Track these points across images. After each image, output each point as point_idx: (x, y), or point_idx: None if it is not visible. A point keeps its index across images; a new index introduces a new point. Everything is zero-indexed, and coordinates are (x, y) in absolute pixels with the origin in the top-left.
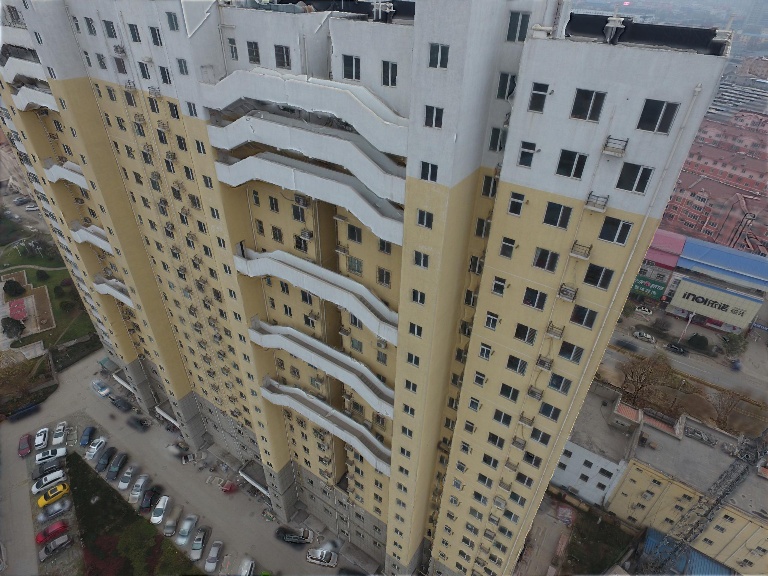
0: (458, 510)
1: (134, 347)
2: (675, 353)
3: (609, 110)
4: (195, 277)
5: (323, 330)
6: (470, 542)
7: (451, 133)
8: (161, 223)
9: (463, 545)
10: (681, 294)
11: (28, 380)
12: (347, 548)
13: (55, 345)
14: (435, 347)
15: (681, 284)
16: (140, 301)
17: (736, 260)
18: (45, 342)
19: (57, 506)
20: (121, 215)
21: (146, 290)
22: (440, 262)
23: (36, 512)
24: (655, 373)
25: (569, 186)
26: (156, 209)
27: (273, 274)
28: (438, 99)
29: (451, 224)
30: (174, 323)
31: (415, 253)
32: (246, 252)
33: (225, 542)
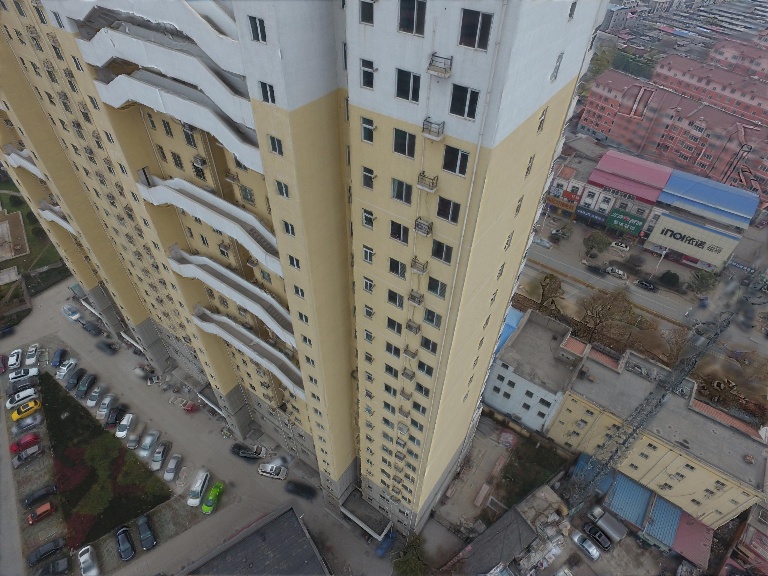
0: (373, 433)
1: (93, 274)
2: (645, 289)
3: (430, 22)
4: (123, 205)
5: (237, 261)
6: (388, 462)
7: (275, 48)
8: (82, 148)
9: (383, 464)
10: (659, 230)
11: (3, 304)
12: (296, 463)
13: (29, 271)
14: (316, 280)
15: (660, 219)
16: (79, 228)
17: (720, 195)
18: (19, 268)
19: (30, 420)
20: (43, 138)
21: (84, 217)
22: (297, 192)
23: (10, 425)
24: (614, 309)
25: (409, 111)
26: (73, 132)
27: (171, 203)
28: (256, 8)
29: (304, 152)
30: (119, 251)
31: (276, 183)
32: (152, 179)
33: (184, 455)
